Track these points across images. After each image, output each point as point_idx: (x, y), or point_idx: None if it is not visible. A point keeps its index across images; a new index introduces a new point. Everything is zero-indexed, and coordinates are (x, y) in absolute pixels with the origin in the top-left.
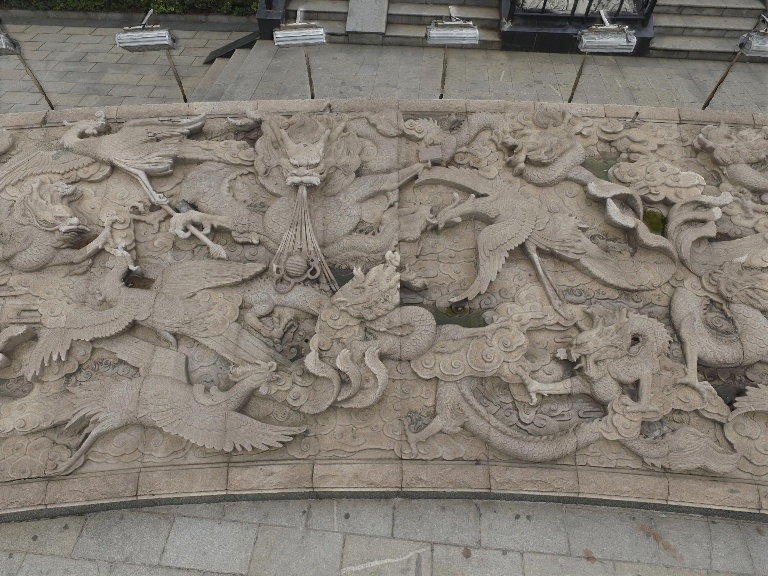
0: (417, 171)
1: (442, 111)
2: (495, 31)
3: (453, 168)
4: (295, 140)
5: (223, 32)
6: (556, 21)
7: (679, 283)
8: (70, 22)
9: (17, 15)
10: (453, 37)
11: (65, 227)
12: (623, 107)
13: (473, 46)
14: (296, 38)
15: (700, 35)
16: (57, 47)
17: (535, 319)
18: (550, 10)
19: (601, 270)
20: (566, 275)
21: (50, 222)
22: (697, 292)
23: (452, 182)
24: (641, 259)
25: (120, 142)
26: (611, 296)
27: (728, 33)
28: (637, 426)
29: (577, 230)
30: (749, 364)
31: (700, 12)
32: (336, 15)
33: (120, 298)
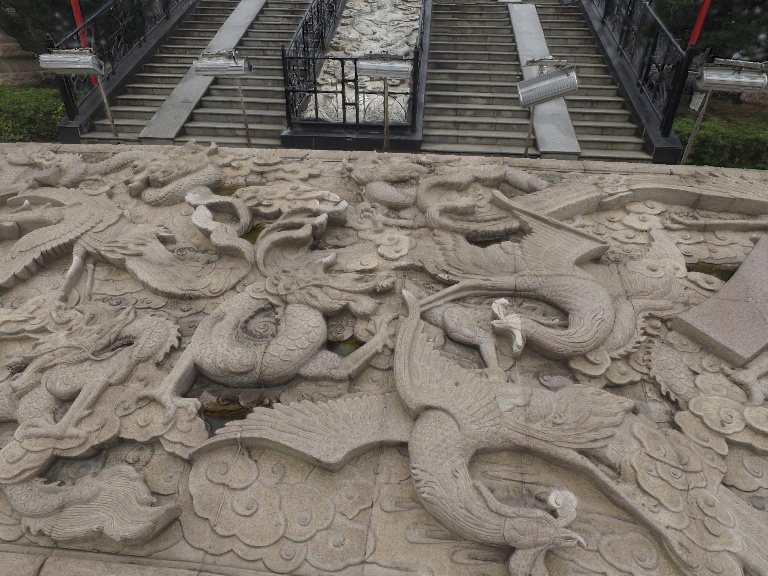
0: (17, 190)
1: (103, 152)
2: None
3: (62, 188)
4: None
5: None
6: (332, 129)
7: (244, 288)
8: None
9: None
10: (66, 61)
11: None
12: (295, 150)
13: None
14: None
15: (474, 143)
16: None
17: (13, 322)
18: (325, 119)
19: (151, 273)
20: (116, 284)
21: None
22: (254, 294)
23: (47, 198)
24: (217, 266)
25: None
26: (154, 304)
27: (499, 141)
28: (31, 459)
29: (151, 236)
30: (285, 380)
31: (475, 127)
32: (139, 128)
33: None
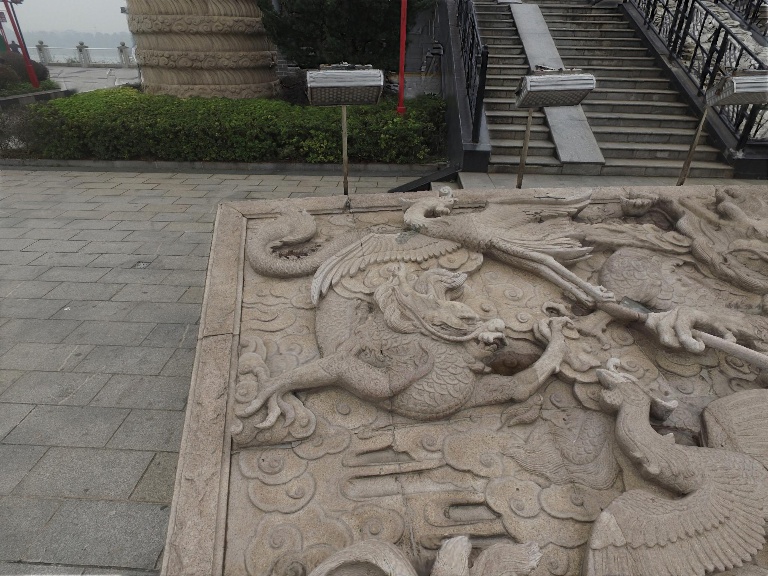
0: None
1: None
2: (716, 162)
3: None
4: (748, 217)
5: (388, 177)
6: None
7: None
8: (218, 171)
9: (160, 166)
10: None
11: (490, 334)
12: None
13: (701, 175)
14: (760, 85)
15: None
16: (214, 188)
17: None
18: None
19: None
20: None
21: (454, 327)
22: None
23: None
24: None
25: (498, 220)
26: None
27: None
28: None
29: None
30: None
31: None
32: (540, 150)
33: (695, 468)
